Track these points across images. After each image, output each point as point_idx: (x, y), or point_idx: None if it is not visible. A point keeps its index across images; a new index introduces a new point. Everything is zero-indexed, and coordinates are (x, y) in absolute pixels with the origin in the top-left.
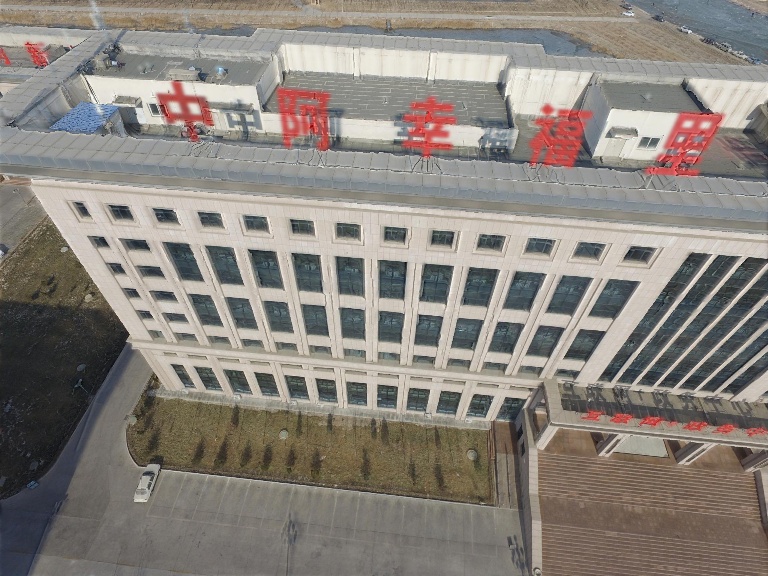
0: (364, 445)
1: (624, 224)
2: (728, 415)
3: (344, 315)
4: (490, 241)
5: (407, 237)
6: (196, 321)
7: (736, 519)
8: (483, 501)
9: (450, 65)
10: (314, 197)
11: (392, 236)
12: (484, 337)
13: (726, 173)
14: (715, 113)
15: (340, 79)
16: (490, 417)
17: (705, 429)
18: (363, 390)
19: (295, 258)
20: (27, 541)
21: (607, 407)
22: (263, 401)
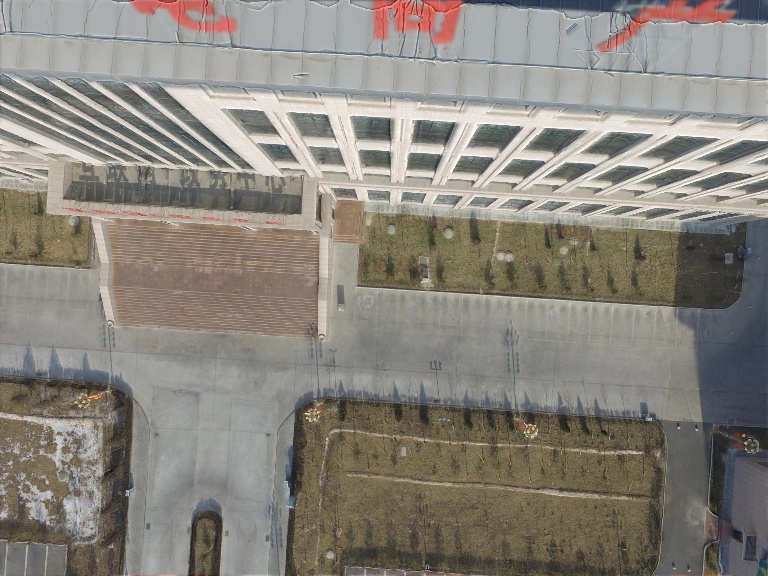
0: None
1: None
2: (256, 192)
3: None
4: None
5: None
6: None
7: (297, 275)
8: (78, 265)
9: None
10: None
11: None
12: None
13: None
14: None
15: None
16: None
17: (208, 215)
18: None
19: None
20: None
21: (127, 189)
22: None
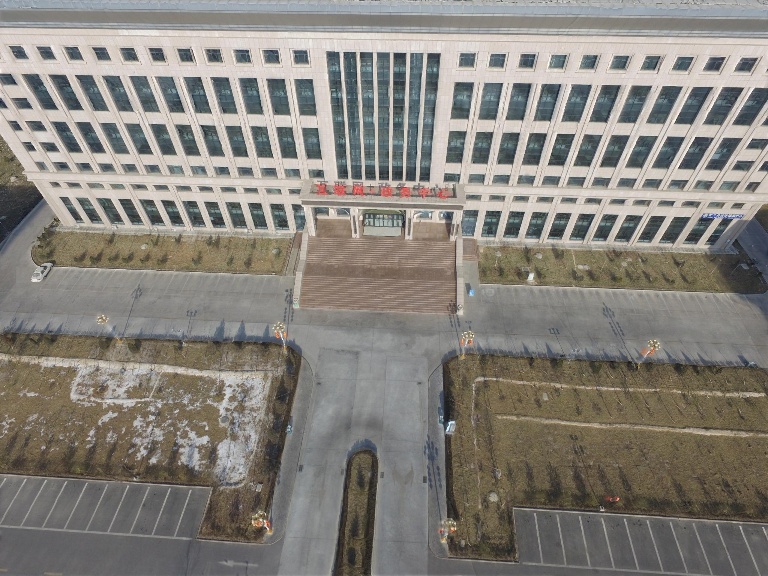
0: (200, 249)
1: (280, 33)
2: None
3: (156, 132)
4: (214, 55)
5: (164, 56)
6: (63, 148)
7: (438, 269)
8: (275, 273)
9: None
10: (94, 23)
11: (157, 57)
12: (248, 142)
13: None
14: None
15: None
16: (293, 229)
17: None
18: (199, 211)
19: (106, 81)
20: None
21: None
22: (133, 229)
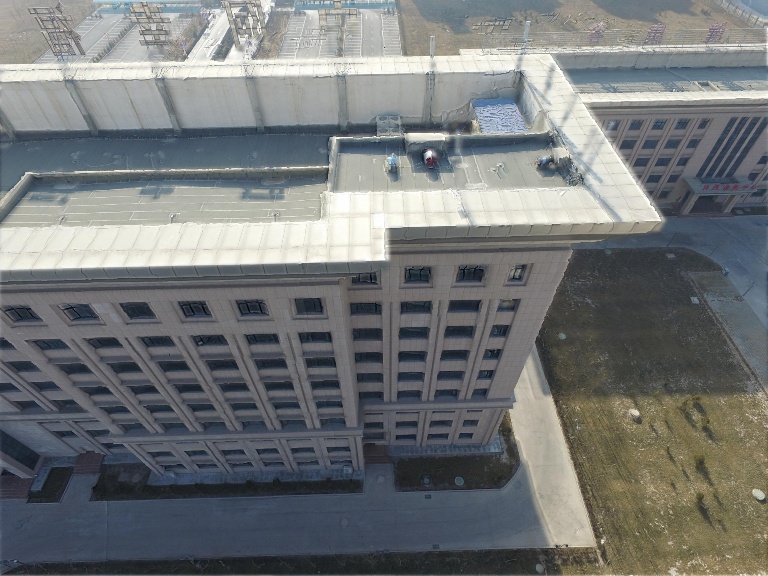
0: None
1: None
2: None
3: None
4: None
5: None
6: None
7: None
8: None
9: None
10: None
11: None
12: None
13: None
14: None
15: None
16: None
17: None
18: None
19: None
20: None
21: None
22: None
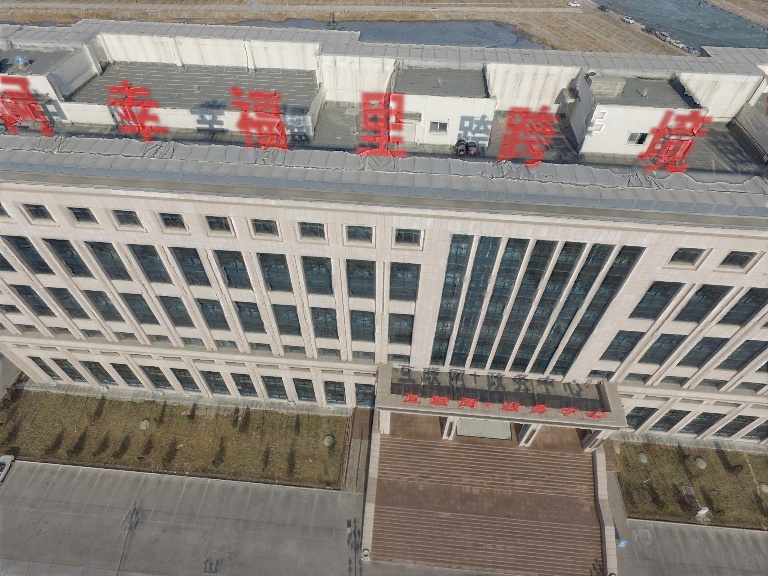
0: (223, 433)
1: (380, 207)
2: (557, 396)
3: (166, 303)
4: (266, 226)
5: (185, 223)
6: (29, 312)
7: (570, 498)
8: (330, 486)
9: (267, 53)
10: (69, 184)
11: (173, 223)
12: (305, 323)
13: (517, 156)
14: (492, 97)
15: (165, 69)
16: (351, 404)
17: (526, 410)
18: (222, 379)
19: (92, 246)
20: None
21: (440, 390)
22: (130, 392)
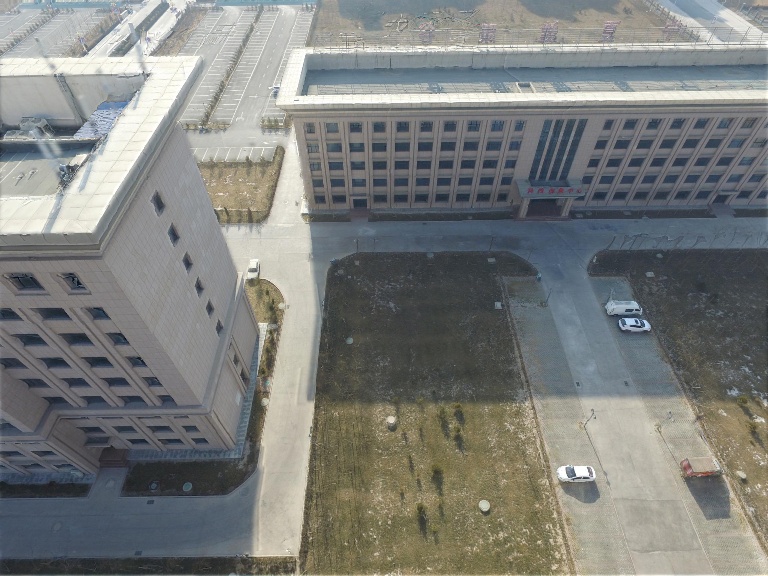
0: None
1: None
2: None
3: None
4: None
5: None
6: None
7: None
8: None
9: None
10: None
11: None
12: None
13: None
14: None
15: None
16: None
17: None
18: None
19: None
20: (320, 241)
21: None
22: None
